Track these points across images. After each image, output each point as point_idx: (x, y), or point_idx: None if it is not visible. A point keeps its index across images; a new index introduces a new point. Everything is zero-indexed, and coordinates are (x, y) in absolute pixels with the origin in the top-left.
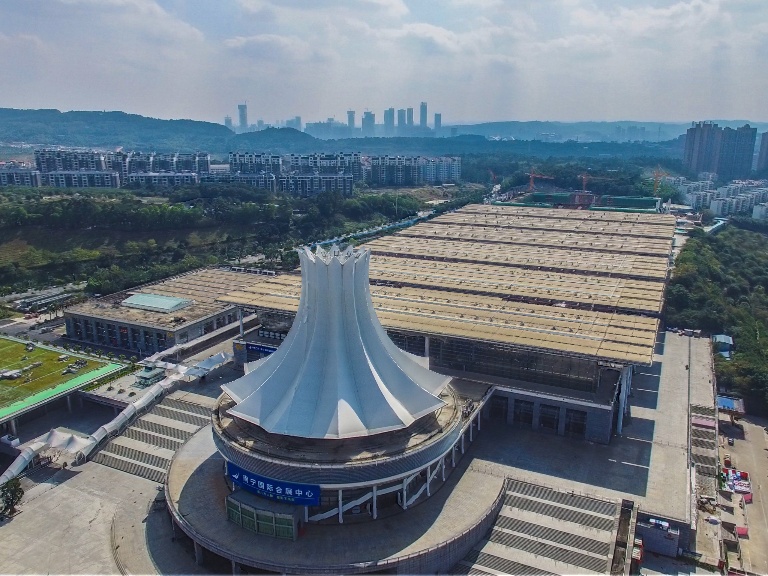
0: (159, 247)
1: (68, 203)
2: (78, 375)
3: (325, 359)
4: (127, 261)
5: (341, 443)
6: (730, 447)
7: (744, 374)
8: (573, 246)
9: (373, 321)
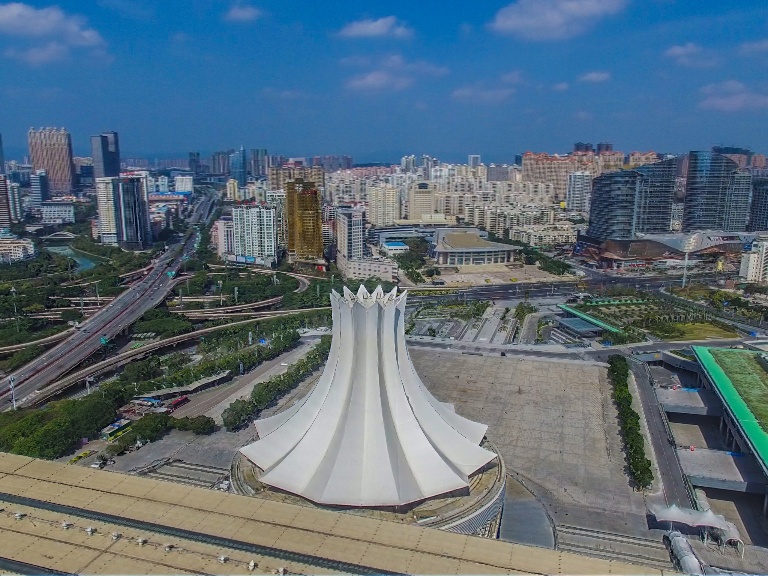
0: None
1: None
2: None
3: None
4: None
5: None
6: None
7: None
8: None
9: None
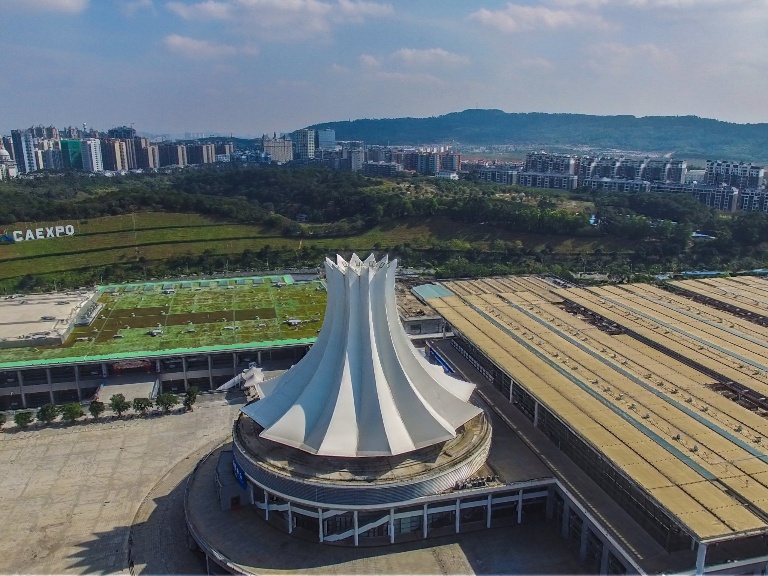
0: (522, 249)
1: (468, 199)
2: None
3: None
4: (492, 257)
5: None
6: None
7: None
8: None
9: (385, 343)
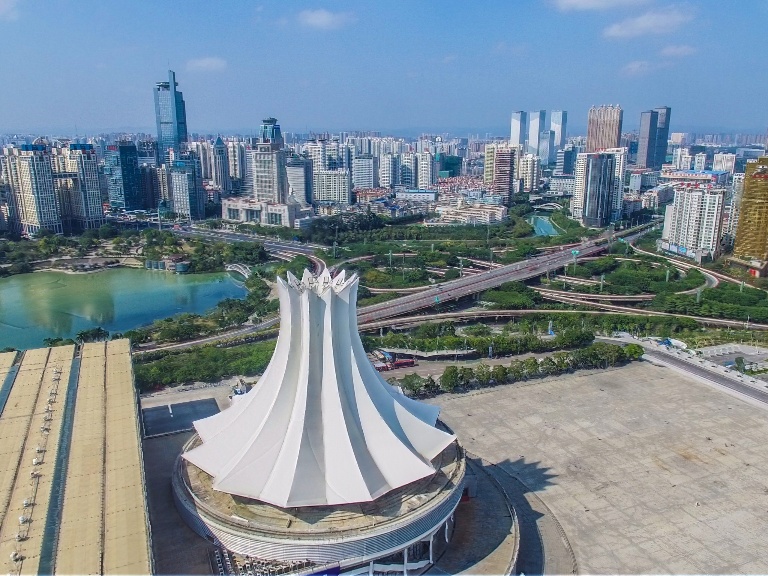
0: None
1: None
2: None
3: None
4: None
5: None
6: None
7: None
8: None
9: None
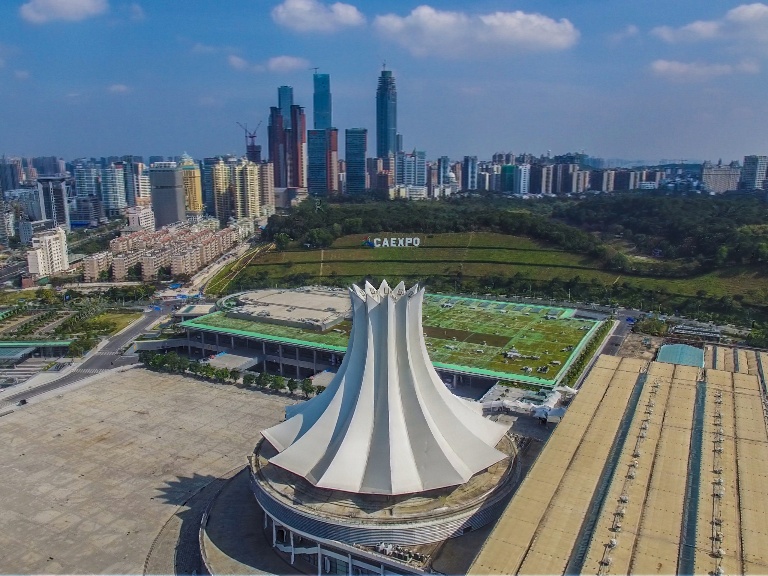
0: None
1: None
2: (522, 374)
3: None
4: None
5: None
6: None
7: None
8: None
9: (383, 376)
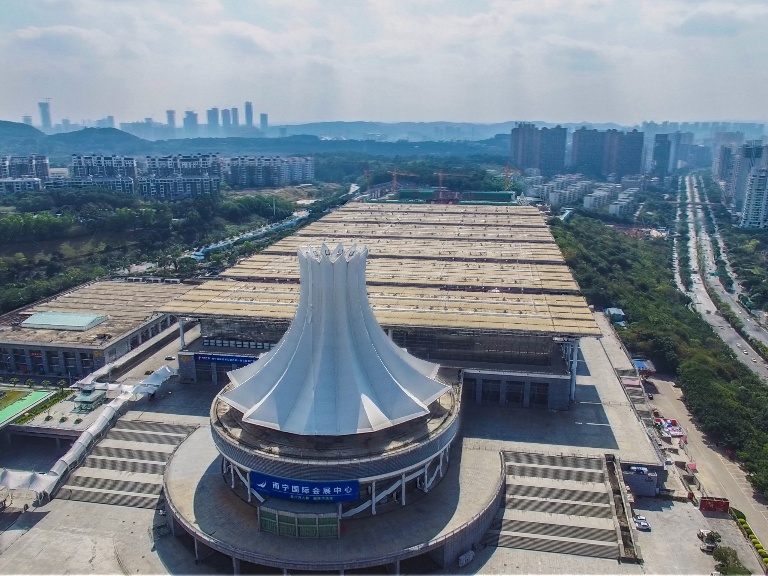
0: (29, 261)
1: None
2: (1, 408)
3: (336, 357)
4: None
5: (368, 436)
6: (652, 401)
7: (646, 339)
8: (470, 238)
9: None
